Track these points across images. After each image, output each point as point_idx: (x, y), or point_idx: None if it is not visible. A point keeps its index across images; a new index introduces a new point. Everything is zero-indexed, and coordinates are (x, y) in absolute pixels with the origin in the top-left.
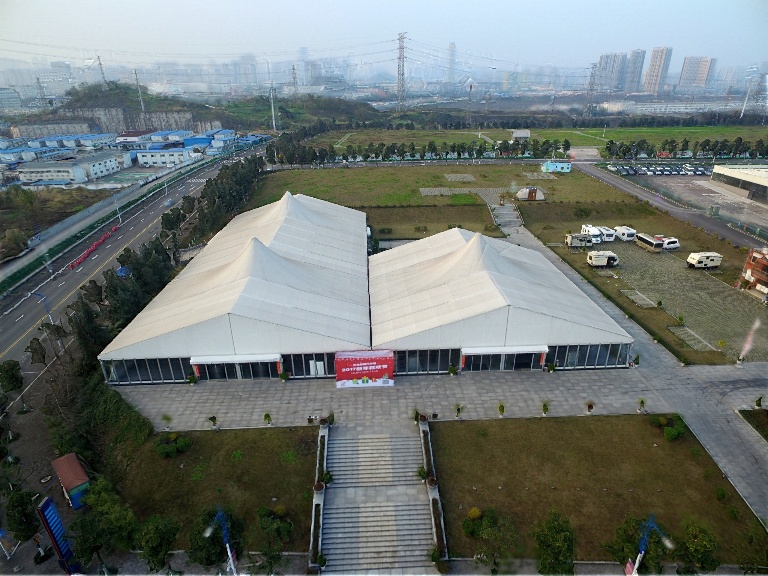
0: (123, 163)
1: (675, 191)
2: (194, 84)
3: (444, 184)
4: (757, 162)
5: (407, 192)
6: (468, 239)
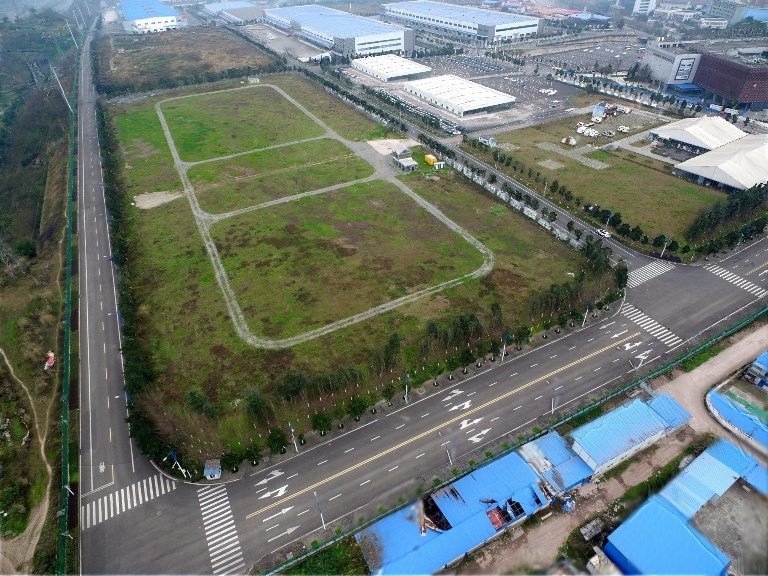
0: None
1: (494, 123)
2: None
3: (576, 166)
4: None
5: (614, 170)
6: None
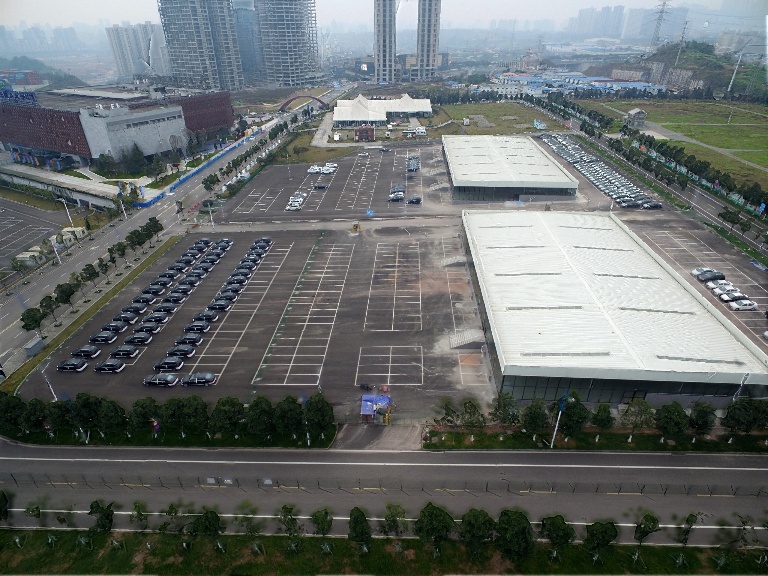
0: (522, 91)
1: None
2: (753, 45)
3: (492, 116)
4: (645, 170)
5: None
6: (376, 107)
